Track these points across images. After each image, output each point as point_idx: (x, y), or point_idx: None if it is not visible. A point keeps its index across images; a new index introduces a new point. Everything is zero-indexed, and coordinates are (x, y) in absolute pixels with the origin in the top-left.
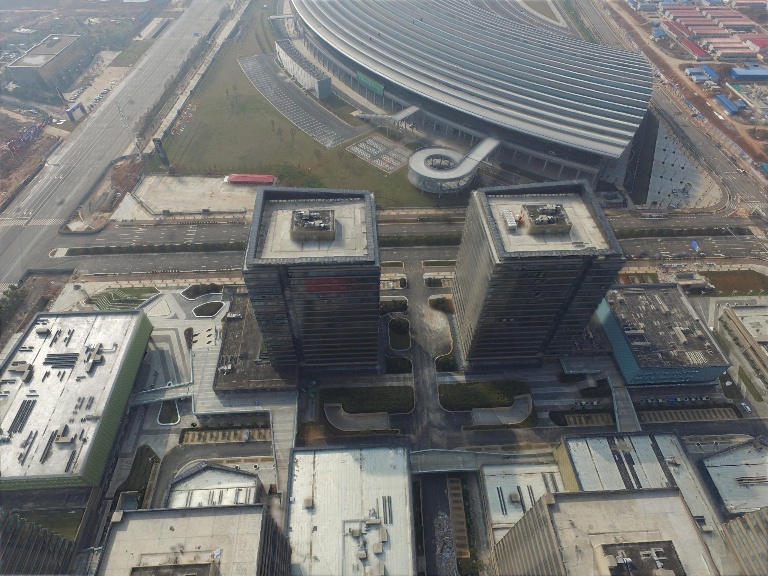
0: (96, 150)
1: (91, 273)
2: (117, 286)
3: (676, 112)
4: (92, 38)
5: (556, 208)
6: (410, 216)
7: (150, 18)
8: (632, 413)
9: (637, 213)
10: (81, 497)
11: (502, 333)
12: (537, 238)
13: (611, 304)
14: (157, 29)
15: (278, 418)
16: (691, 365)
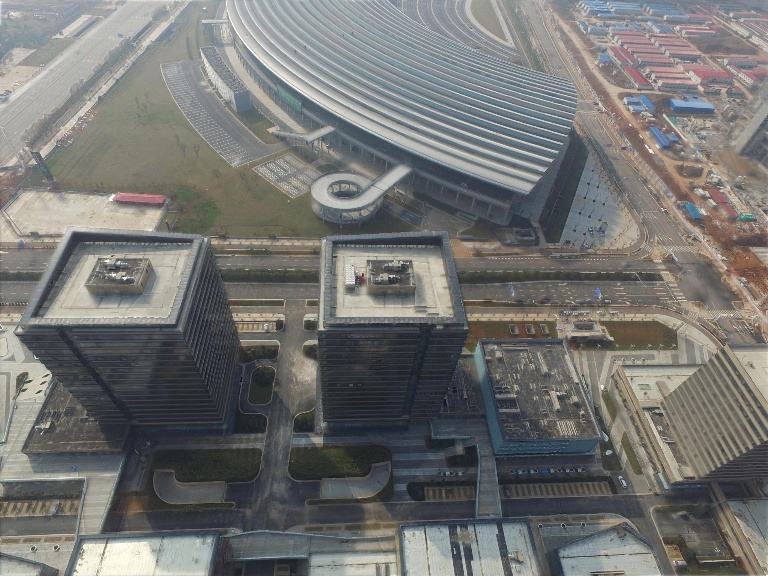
0: None
1: None
2: None
3: (606, 144)
4: (6, 33)
5: (404, 265)
6: (305, 247)
7: (77, 15)
8: (495, 488)
9: (548, 252)
10: None
11: (354, 397)
12: (376, 299)
13: (488, 362)
14: (82, 27)
15: (93, 488)
16: (559, 438)
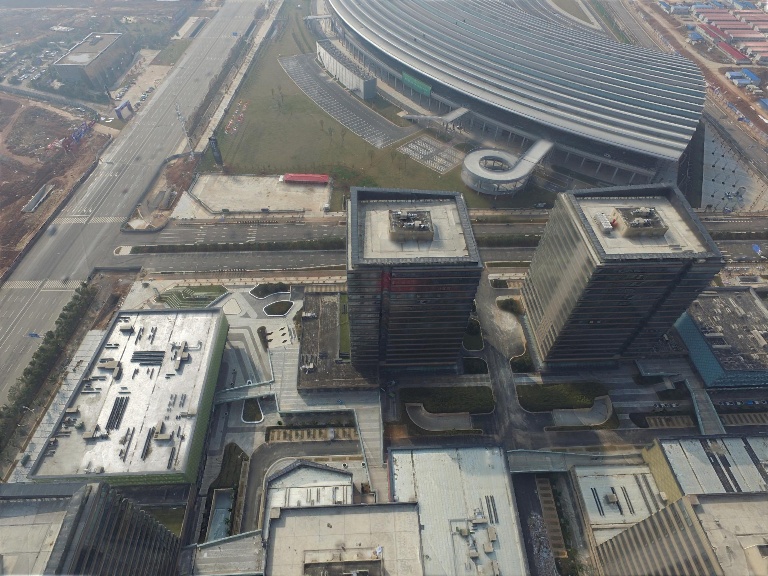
0: (148, 148)
1: (158, 271)
2: (185, 284)
3: (722, 116)
4: (131, 36)
5: (649, 211)
6: None
7: (186, 17)
8: (714, 415)
9: None
10: (180, 494)
11: (586, 335)
12: (633, 241)
13: None
14: (194, 28)
15: (363, 417)
16: None
